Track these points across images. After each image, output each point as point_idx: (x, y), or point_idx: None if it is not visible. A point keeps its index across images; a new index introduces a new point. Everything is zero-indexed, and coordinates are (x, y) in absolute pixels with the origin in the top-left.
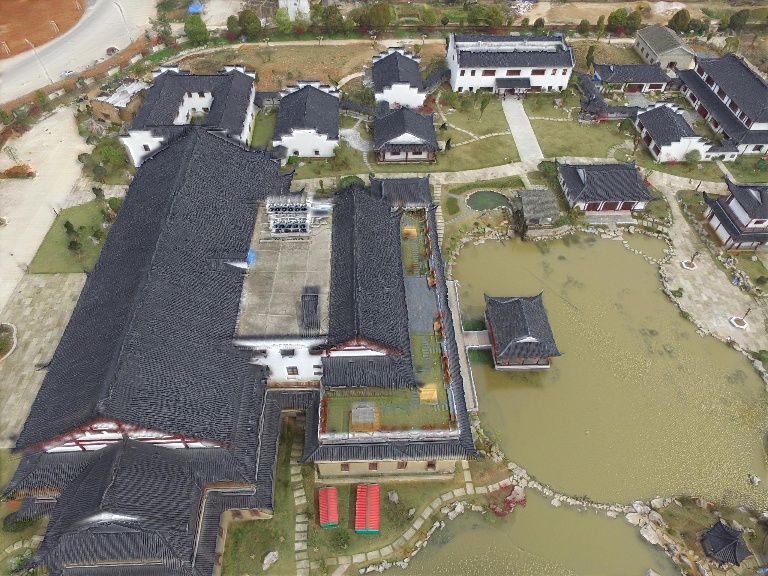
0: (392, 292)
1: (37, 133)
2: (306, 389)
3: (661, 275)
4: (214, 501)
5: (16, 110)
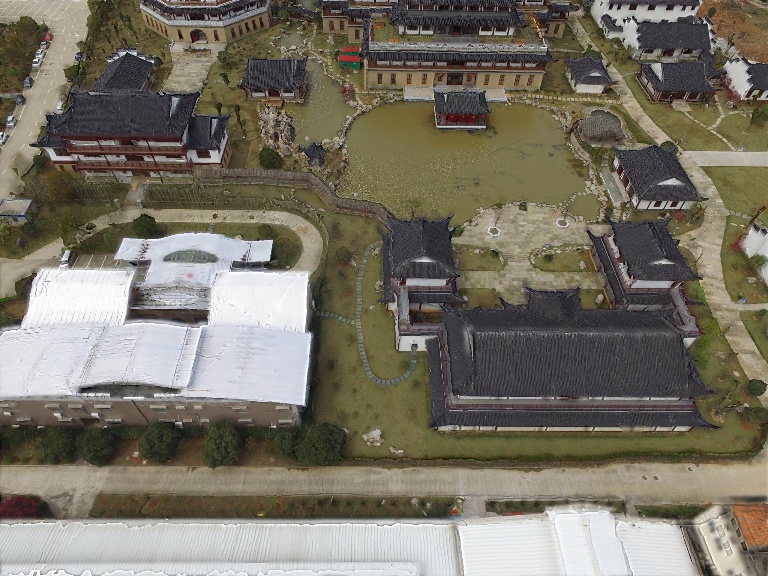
0: (443, 1)
1: None
2: None
3: None
4: (347, 3)
5: None
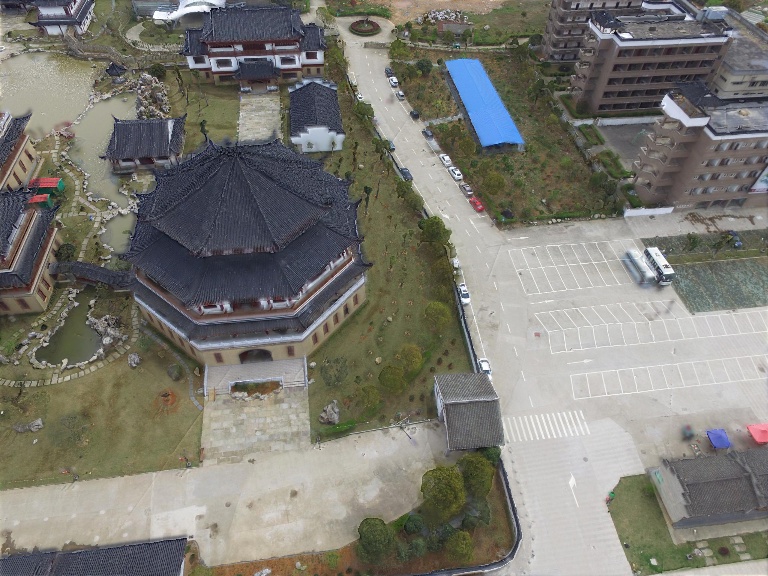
0: None
1: None
2: None
3: None
4: None
5: None
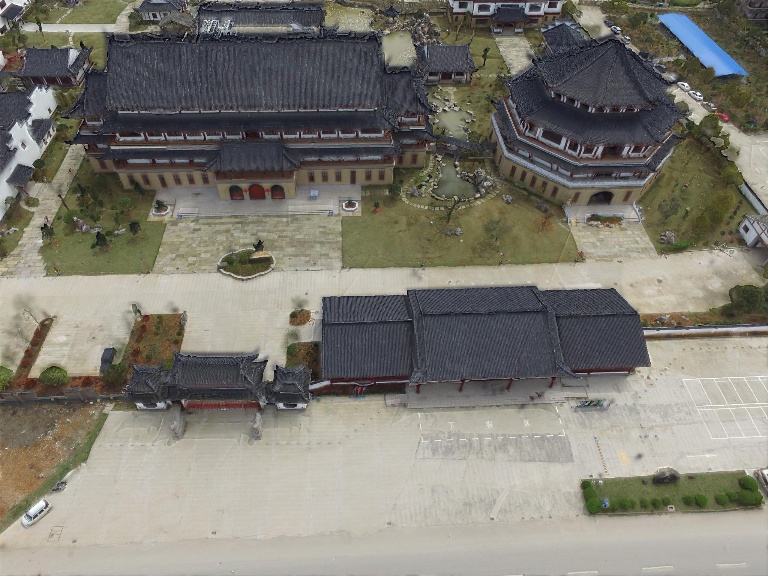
0: None
1: None
2: None
3: None
4: None
5: None
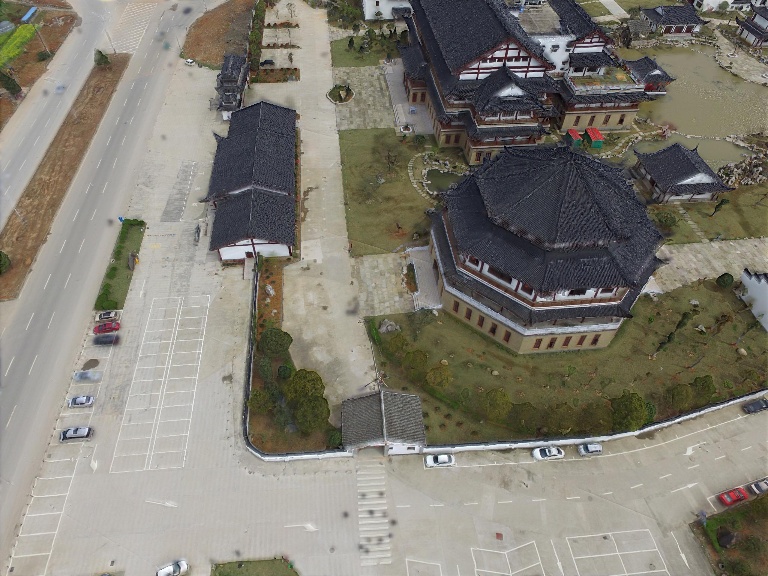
0: None
1: (281, 7)
2: (555, 79)
3: (717, 60)
4: None
5: None
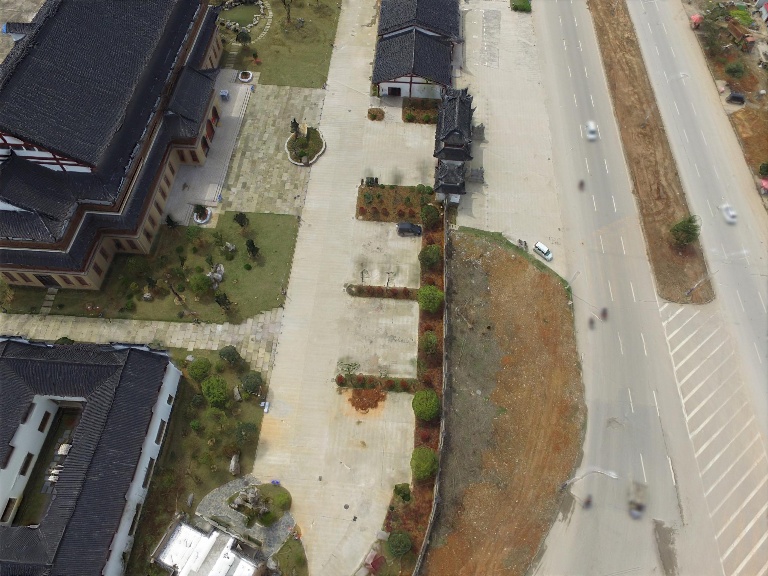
0: None
1: (370, 509)
2: None
3: None
4: None
5: (404, 540)
